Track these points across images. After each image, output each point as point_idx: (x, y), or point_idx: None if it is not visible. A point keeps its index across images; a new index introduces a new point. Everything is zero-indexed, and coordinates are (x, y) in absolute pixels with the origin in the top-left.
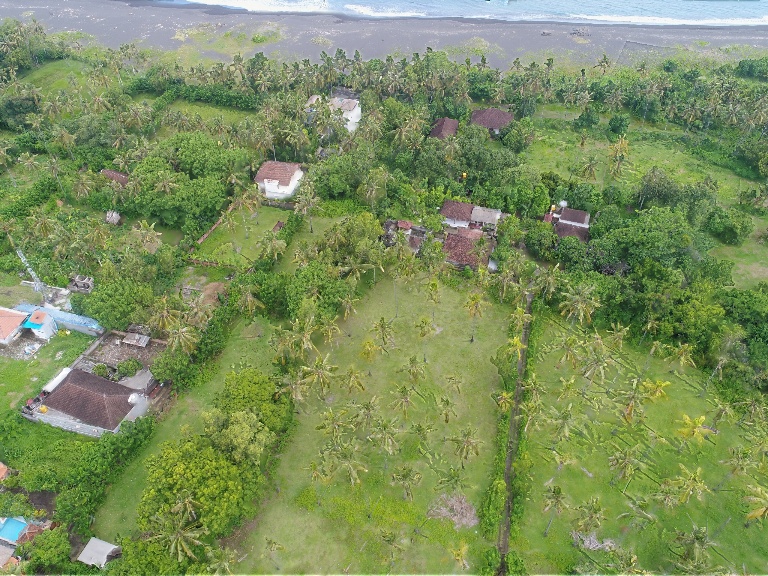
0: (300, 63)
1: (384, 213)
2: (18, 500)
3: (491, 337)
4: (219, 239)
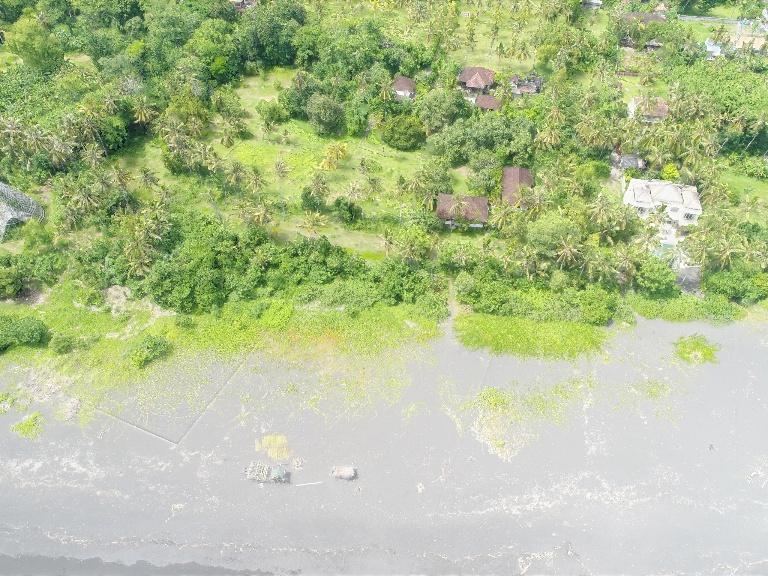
0: (764, 244)
1: (544, 94)
2: (640, 5)
3: (457, 52)
4: (658, 89)
